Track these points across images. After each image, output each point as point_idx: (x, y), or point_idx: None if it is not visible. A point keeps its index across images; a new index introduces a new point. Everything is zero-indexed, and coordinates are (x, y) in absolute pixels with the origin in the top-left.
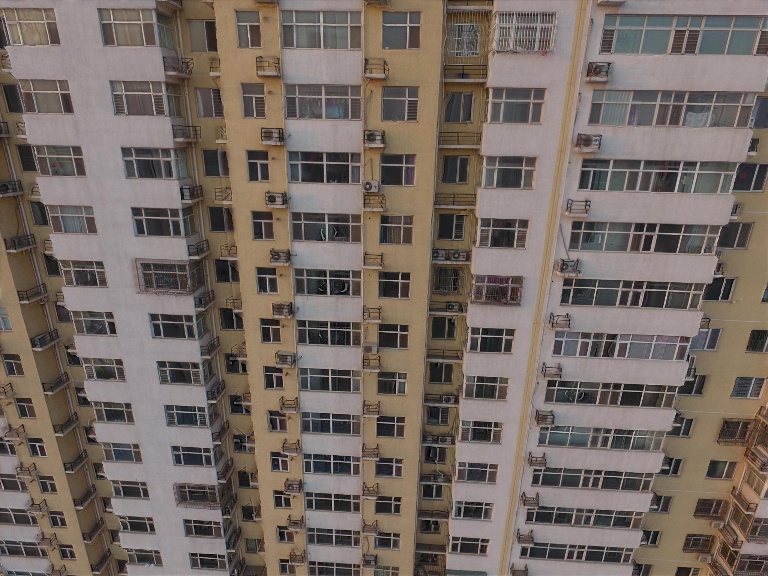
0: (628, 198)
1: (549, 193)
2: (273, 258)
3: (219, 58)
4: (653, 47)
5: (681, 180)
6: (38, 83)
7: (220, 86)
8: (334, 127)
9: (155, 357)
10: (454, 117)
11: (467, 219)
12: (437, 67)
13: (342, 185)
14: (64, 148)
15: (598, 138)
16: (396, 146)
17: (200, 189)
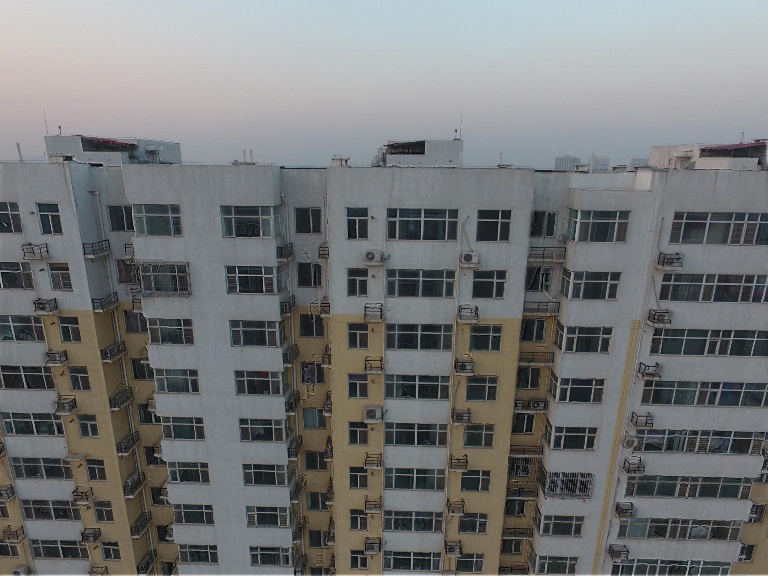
0: None
1: None
2: None
3: (334, 493)
4: (664, 492)
5: (689, 571)
6: (188, 506)
7: (333, 511)
8: (421, 537)
9: None
10: (511, 512)
11: None
12: (502, 503)
13: (425, 573)
14: (203, 546)
15: (626, 553)
16: (469, 549)
17: (305, 556)
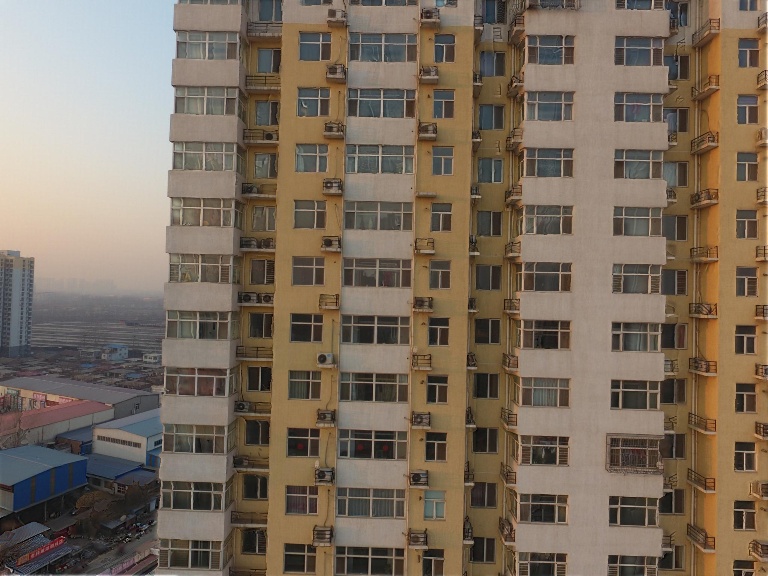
0: None
1: None
2: (764, 432)
3: (717, 246)
4: None
5: None
6: (543, 265)
7: (717, 269)
8: None
9: (607, 550)
10: None
11: None
12: None
13: None
14: (554, 322)
15: None
16: None
17: None
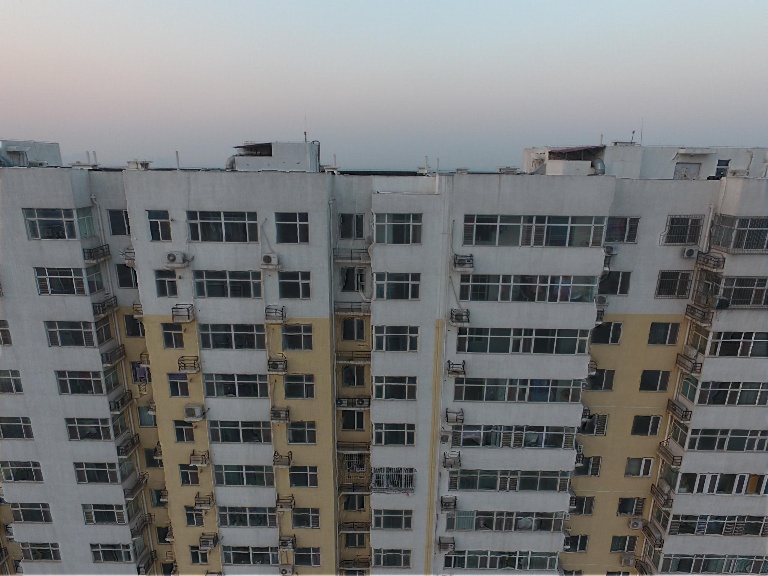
0: (481, 574)
1: (422, 571)
2: None
3: (167, 490)
4: (486, 485)
5: (519, 562)
6: (25, 505)
7: (168, 508)
8: (257, 532)
9: None
10: (351, 507)
11: (367, 570)
12: (331, 498)
13: (265, 567)
14: (44, 543)
15: (452, 545)
16: (305, 543)
17: (154, 553)
